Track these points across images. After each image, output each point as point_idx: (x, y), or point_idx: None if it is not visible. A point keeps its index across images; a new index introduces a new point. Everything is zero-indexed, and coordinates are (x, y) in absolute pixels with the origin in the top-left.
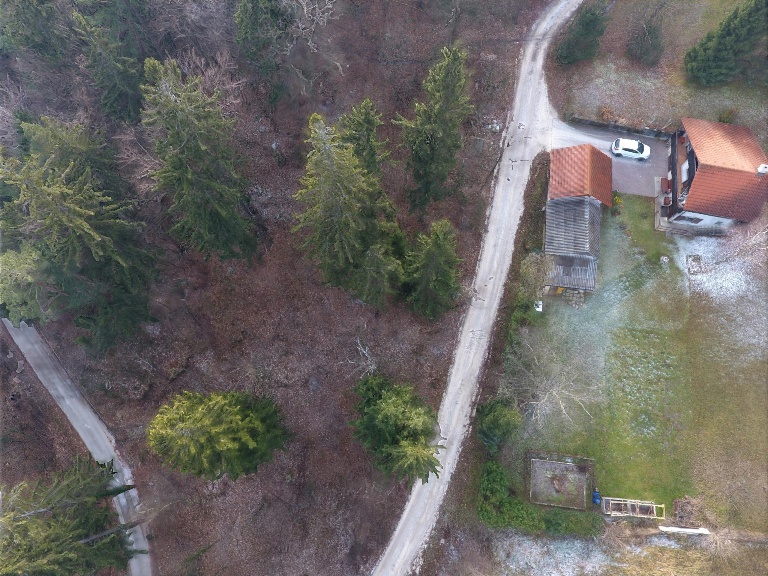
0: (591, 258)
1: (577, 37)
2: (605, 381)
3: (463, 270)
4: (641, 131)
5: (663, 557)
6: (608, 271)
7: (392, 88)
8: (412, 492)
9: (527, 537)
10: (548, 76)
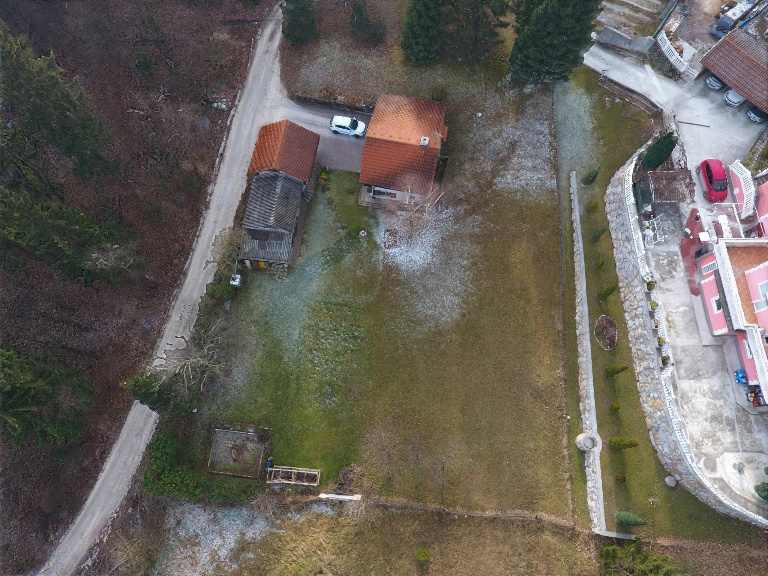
0: (285, 232)
1: (288, 15)
2: (297, 353)
3: (179, 246)
4: (361, 109)
5: (317, 523)
6: (313, 246)
7: (127, 68)
8: (106, 462)
9: (197, 505)
10: (282, 55)
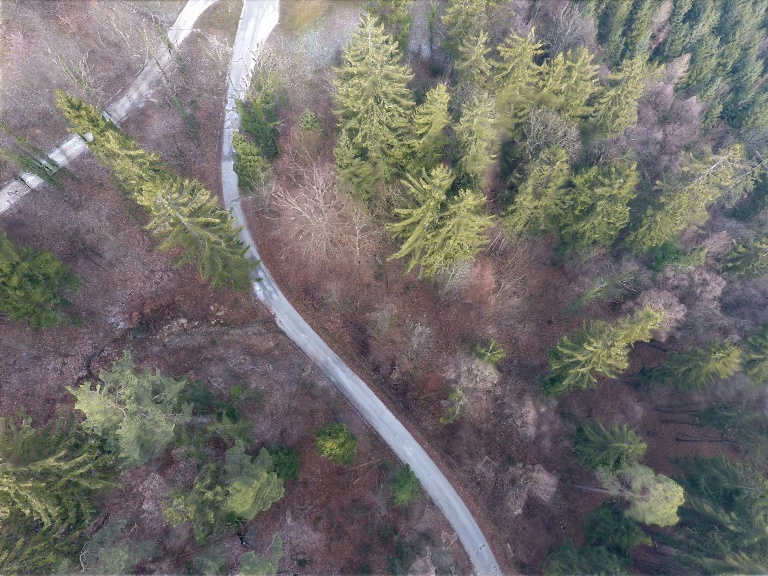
0: None
1: None
2: None
3: None
4: None
5: None
6: None
7: None
8: None
9: None
10: None
